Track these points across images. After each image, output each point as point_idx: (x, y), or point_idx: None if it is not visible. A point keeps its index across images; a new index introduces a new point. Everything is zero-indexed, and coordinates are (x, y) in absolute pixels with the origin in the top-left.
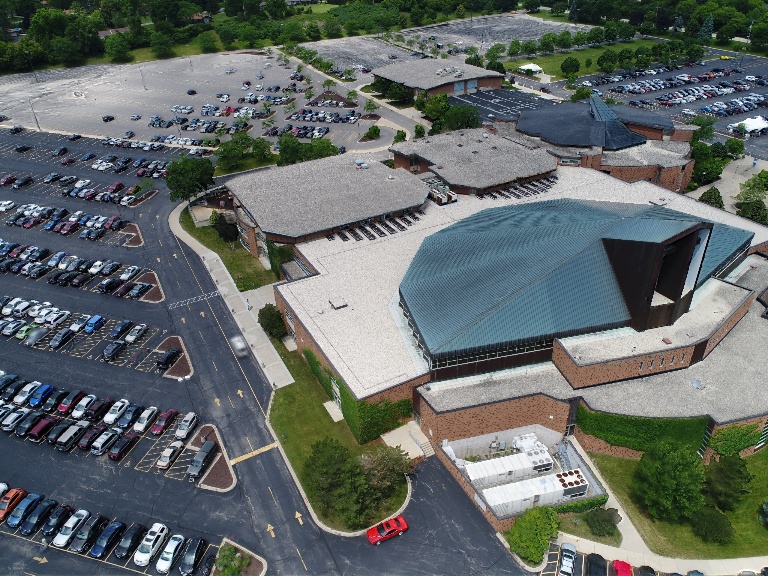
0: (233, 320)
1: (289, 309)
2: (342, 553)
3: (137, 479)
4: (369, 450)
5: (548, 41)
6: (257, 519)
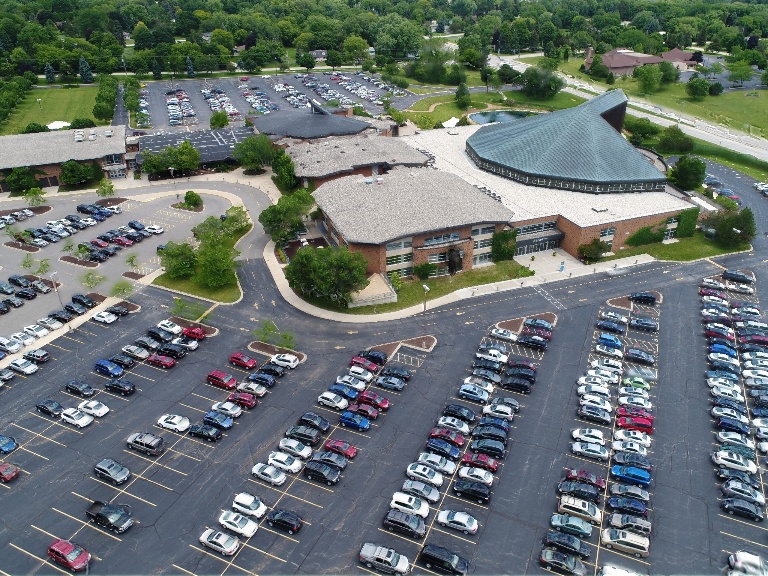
0: (579, 277)
1: (613, 223)
2: (762, 246)
3: (766, 301)
4: (695, 235)
5: (5, 102)
6: (762, 264)
